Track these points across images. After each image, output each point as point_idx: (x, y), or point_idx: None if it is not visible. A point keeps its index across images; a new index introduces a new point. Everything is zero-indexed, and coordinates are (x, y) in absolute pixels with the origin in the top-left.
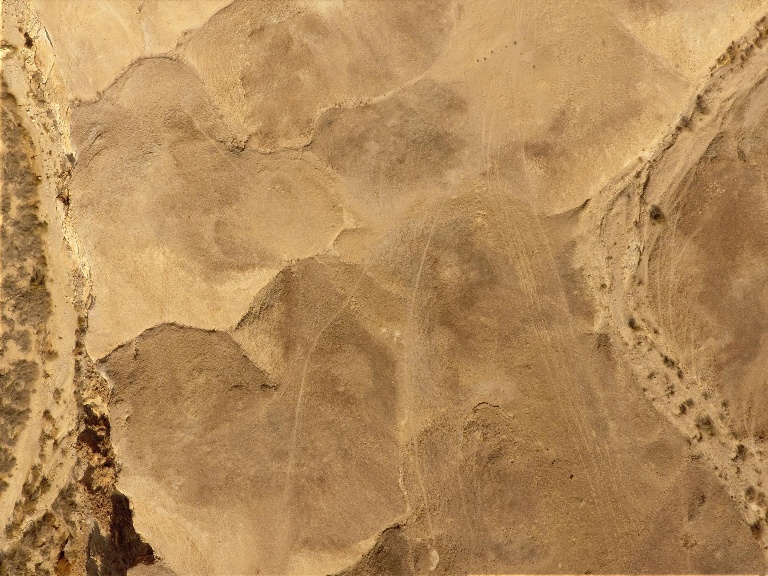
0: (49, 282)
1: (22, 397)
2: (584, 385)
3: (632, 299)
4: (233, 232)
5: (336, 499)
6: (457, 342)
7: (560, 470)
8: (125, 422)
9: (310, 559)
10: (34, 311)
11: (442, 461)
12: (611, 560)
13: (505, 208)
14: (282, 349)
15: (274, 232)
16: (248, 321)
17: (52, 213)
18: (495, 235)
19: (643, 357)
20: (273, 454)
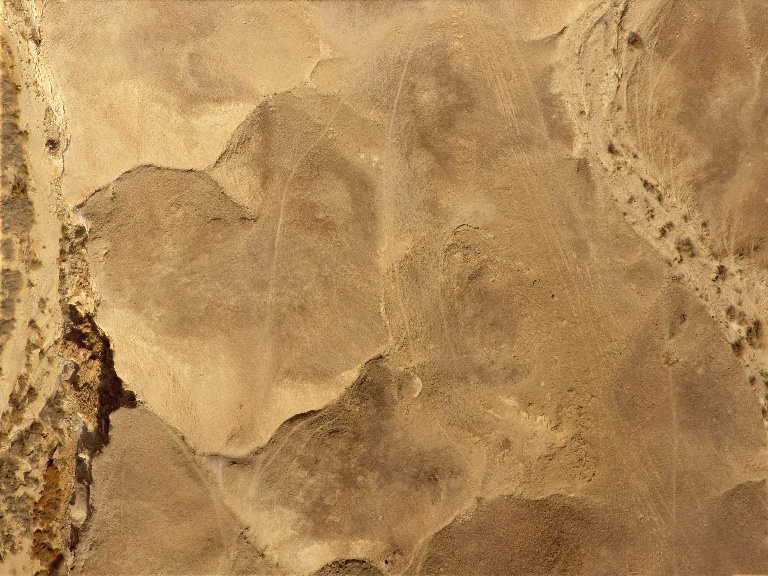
0: (31, 191)
1: (6, 306)
2: (564, 205)
3: (611, 125)
4: (208, 65)
5: (317, 327)
6: (436, 163)
7: (541, 290)
8: (103, 258)
9: (293, 391)
10: (16, 219)
11: (423, 286)
12: (593, 378)
13: (482, 32)
14: (260, 179)
15: (250, 65)
16: (226, 157)
17: (33, 122)
18: (472, 58)
19: (622, 179)
20: (253, 284)
